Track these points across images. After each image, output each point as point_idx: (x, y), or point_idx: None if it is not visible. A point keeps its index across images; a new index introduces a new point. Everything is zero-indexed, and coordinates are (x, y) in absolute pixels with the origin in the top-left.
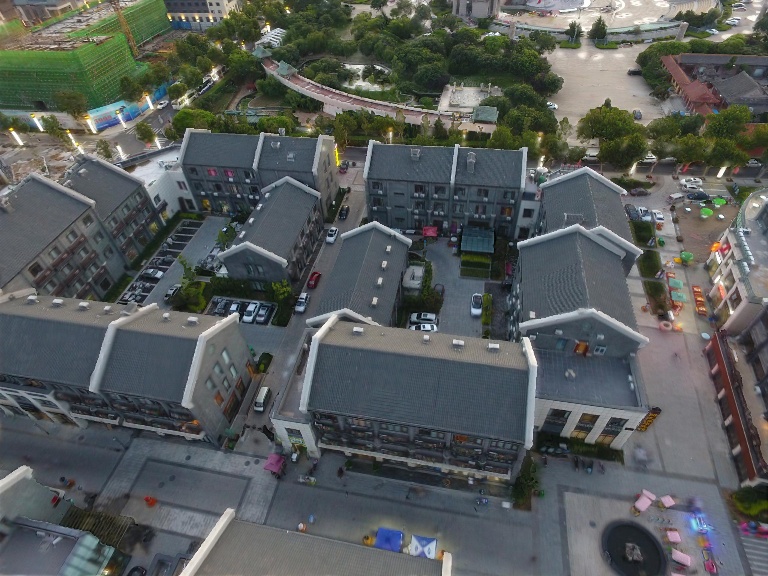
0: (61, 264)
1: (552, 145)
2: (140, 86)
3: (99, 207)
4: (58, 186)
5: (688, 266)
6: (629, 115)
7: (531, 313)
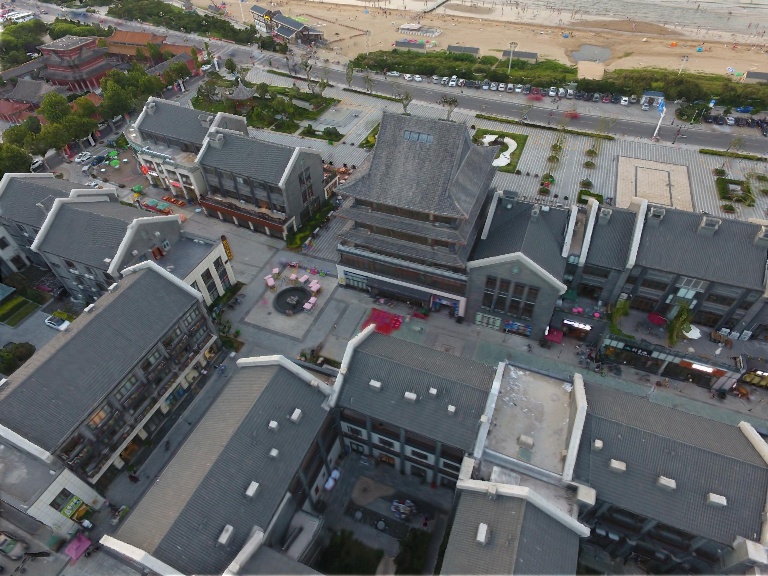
0: None
1: None
2: None
3: None
4: None
5: (146, 193)
6: None
7: (105, 260)
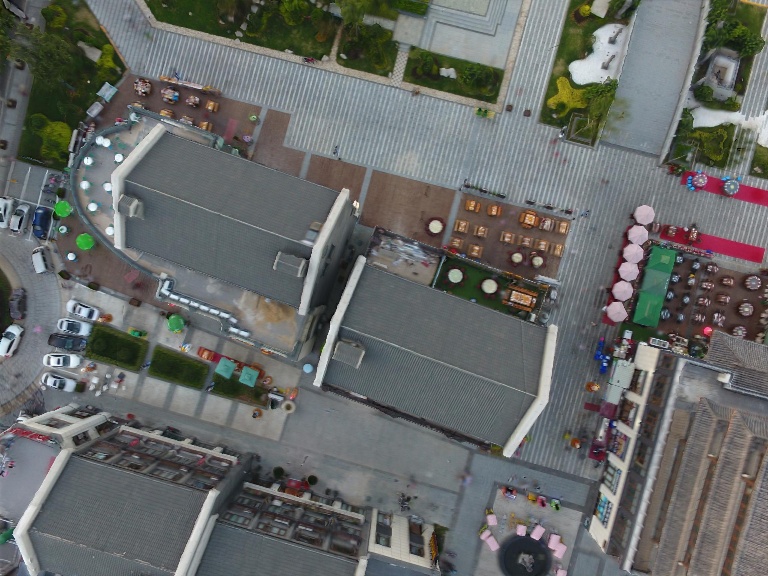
0: None
1: None
2: None
3: None
4: None
5: (189, 320)
6: None
7: None
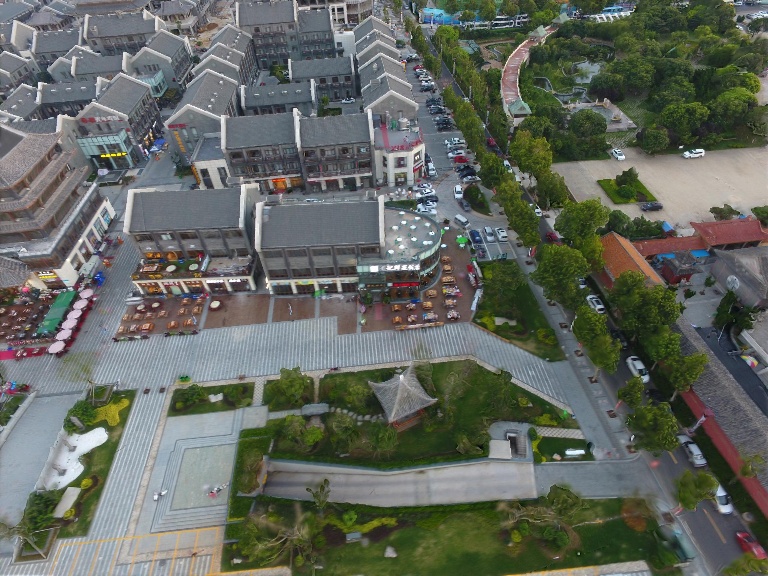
0: (267, 35)
1: (470, 133)
2: (458, 5)
3: (305, 27)
4: (294, 7)
5: None
6: (539, 152)
7: None
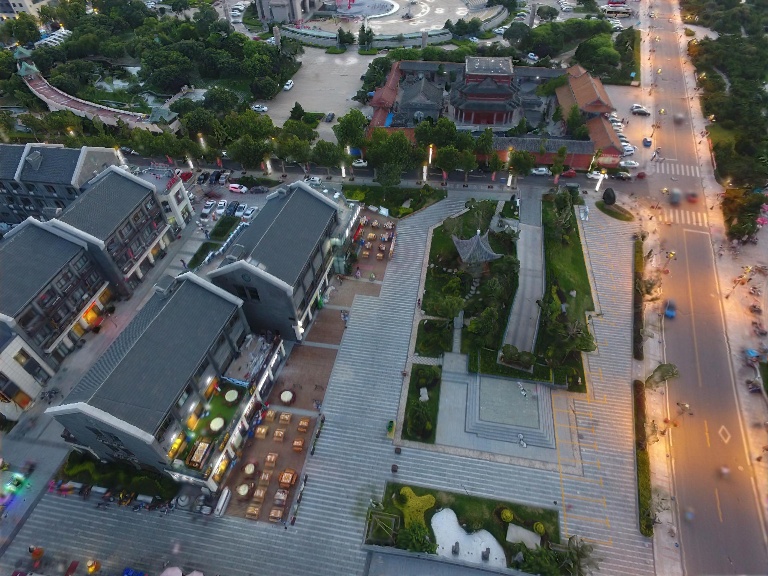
0: None
1: (180, 145)
2: None
3: None
4: None
5: None
6: (263, 118)
7: None
